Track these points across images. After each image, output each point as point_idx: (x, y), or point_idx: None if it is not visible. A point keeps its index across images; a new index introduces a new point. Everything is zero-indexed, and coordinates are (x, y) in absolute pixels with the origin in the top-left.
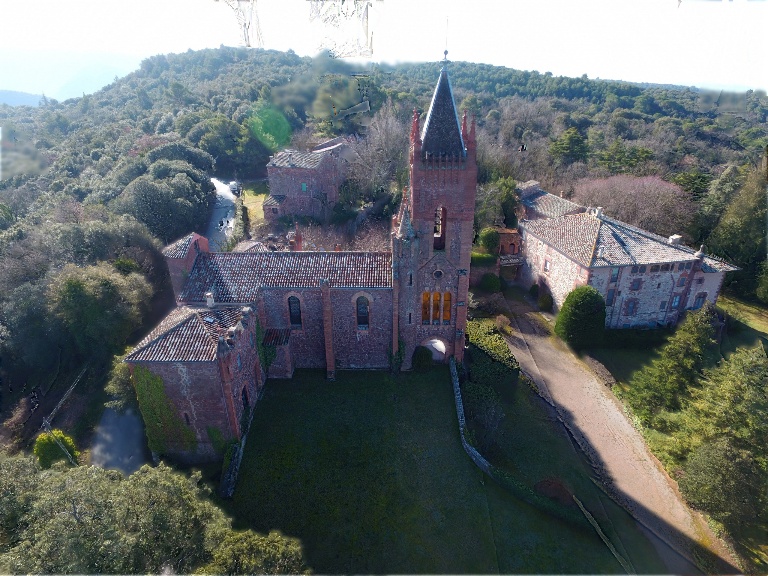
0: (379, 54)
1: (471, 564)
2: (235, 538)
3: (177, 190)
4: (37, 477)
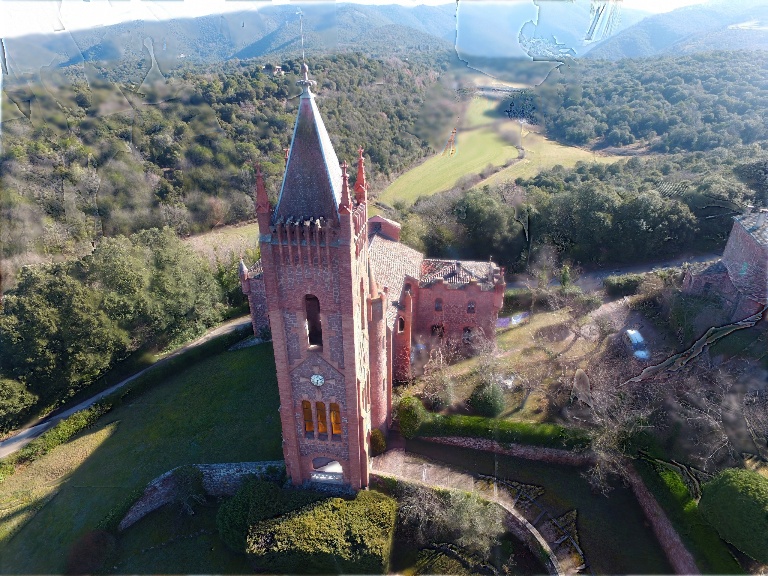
0: (510, 56)
1: (95, 466)
2: (86, 288)
3: (627, 206)
4: (166, 247)
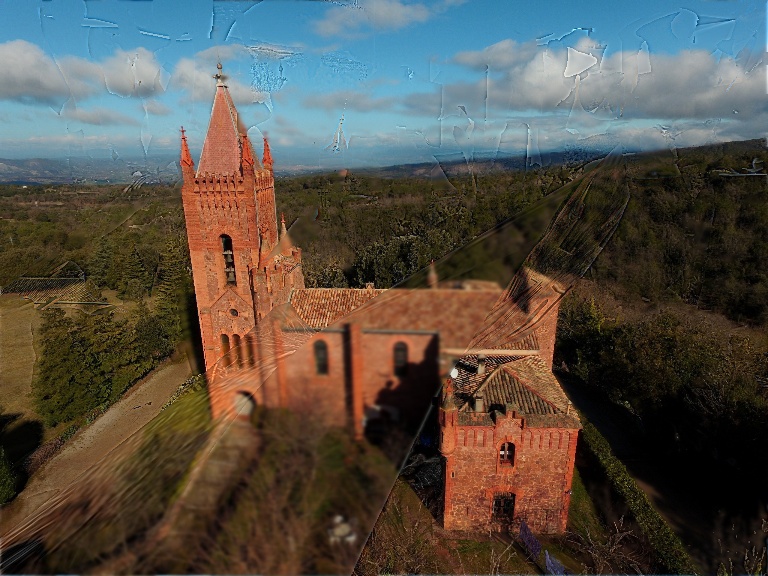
0: None
1: None
2: None
3: None
4: None
